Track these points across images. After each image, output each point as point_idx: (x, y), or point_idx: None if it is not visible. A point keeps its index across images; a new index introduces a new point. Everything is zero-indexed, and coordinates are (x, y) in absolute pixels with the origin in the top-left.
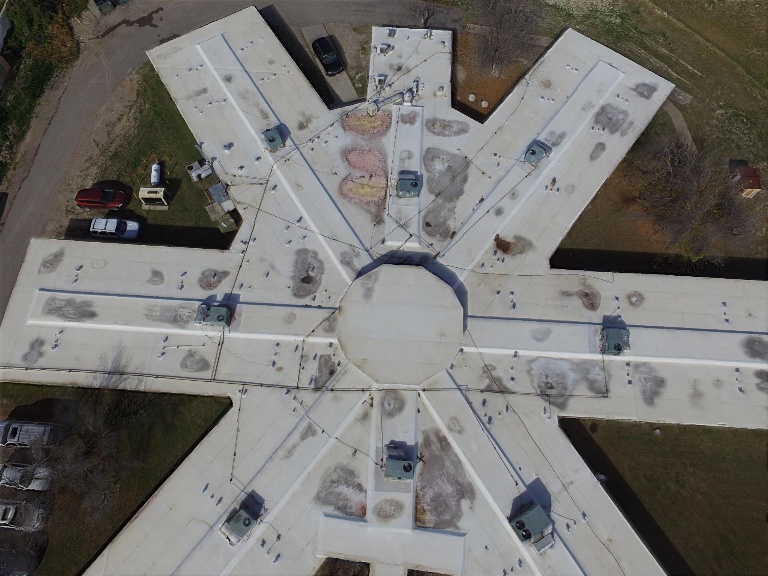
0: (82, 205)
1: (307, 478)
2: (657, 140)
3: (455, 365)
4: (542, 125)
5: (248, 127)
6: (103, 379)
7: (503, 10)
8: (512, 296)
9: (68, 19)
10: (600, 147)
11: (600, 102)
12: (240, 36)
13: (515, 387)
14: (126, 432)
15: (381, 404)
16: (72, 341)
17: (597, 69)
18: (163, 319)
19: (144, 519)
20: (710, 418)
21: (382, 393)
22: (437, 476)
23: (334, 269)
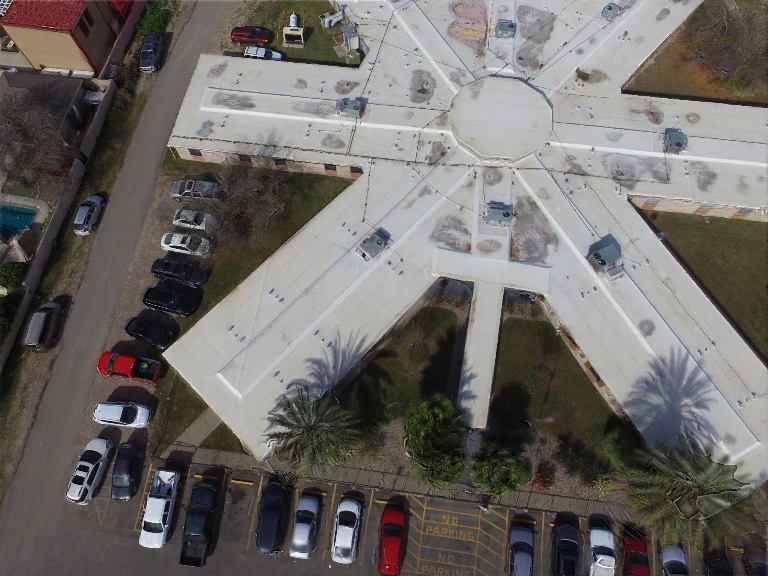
0: (236, 39)
1: (424, 223)
2: (712, 18)
3: (543, 154)
4: None
5: None
6: (261, 149)
7: None
8: (590, 110)
9: None
10: (665, 12)
11: None
12: None
13: (592, 172)
14: None
15: (483, 176)
16: (236, 123)
17: None
18: (308, 111)
19: (295, 243)
20: (754, 203)
21: (484, 168)
22: (528, 227)
23: (444, 85)
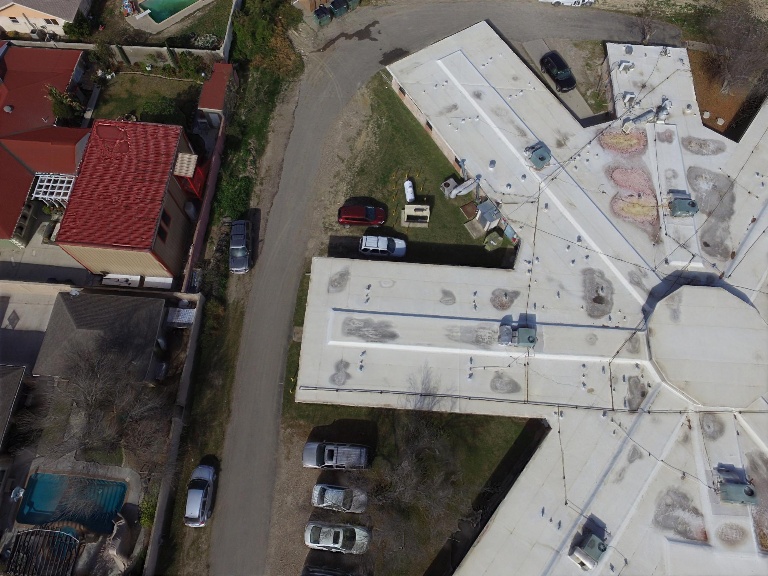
0: (345, 222)
1: (642, 501)
2: None
3: None
4: None
5: (507, 144)
6: (416, 400)
7: (717, 26)
8: None
9: (286, 32)
10: None
11: None
12: (478, 52)
13: None
14: None
15: (701, 426)
16: (377, 362)
17: None
18: (465, 340)
19: (487, 543)
20: None
21: (700, 415)
22: None
23: (623, 289)
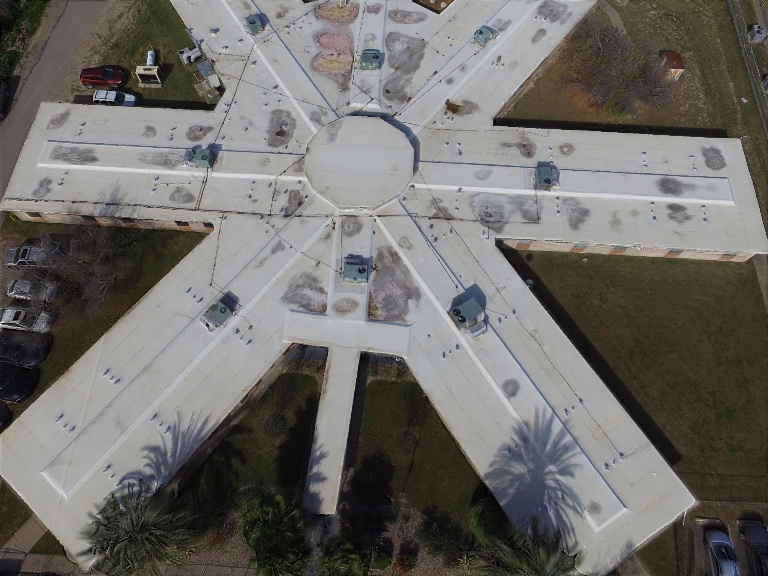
0: (86, 81)
1: (276, 283)
2: None
3: (407, 198)
4: (491, 15)
5: (232, 16)
6: (102, 209)
7: None
8: (459, 146)
9: None
10: (541, 32)
11: None
12: None
13: (459, 215)
14: (121, 258)
15: (342, 226)
16: (76, 180)
17: None
18: (155, 162)
19: (136, 314)
20: (627, 240)
21: (343, 218)
22: (388, 282)
23: (304, 125)
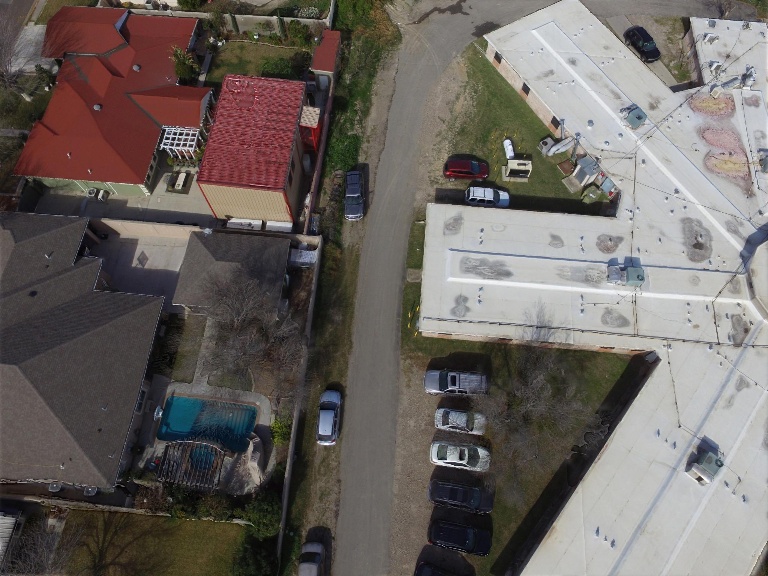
0: (451, 175)
1: (751, 426)
2: None
3: None
4: None
5: (603, 106)
6: (533, 332)
7: None
8: None
9: (383, 6)
10: None
11: None
12: (570, 23)
13: None
14: None
15: None
16: (494, 297)
17: None
18: (576, 279)
19: (607, 460)
20: None
21: None
22: None
23: (721, 237)
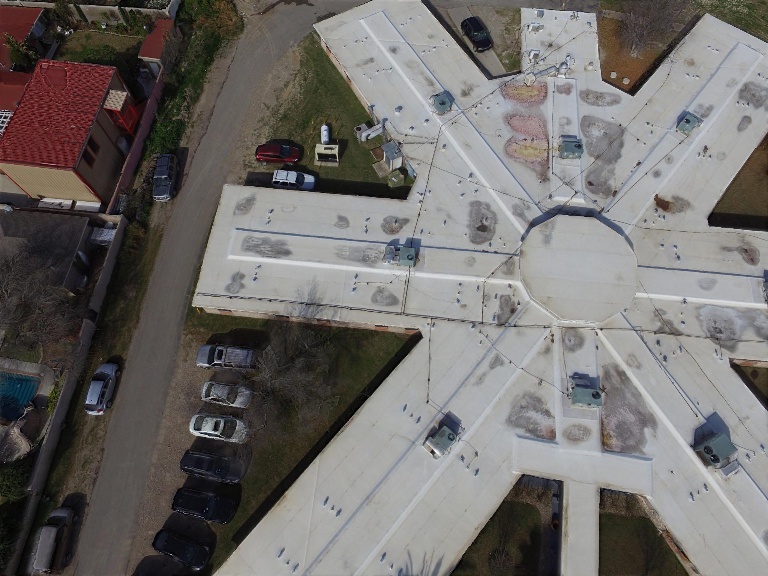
0: (261, 159)
1: (498, 403)
2: None
3: (628, 309)
4: (689, 99)
5: (414, 93)
6: (301, 309)
7: None
8: (676, 249)
9: None
10: (746, 120)
11: (743, 80)
12: (399, 13)
13: (686, 330)
14: None
15: (563, 340)
16: (270, 274)
17: (737, 50)
18: (353, 258)
19: (350, 433)
20: None
21: (563, 330)
22: (620, 406)
23: (506, 220)
